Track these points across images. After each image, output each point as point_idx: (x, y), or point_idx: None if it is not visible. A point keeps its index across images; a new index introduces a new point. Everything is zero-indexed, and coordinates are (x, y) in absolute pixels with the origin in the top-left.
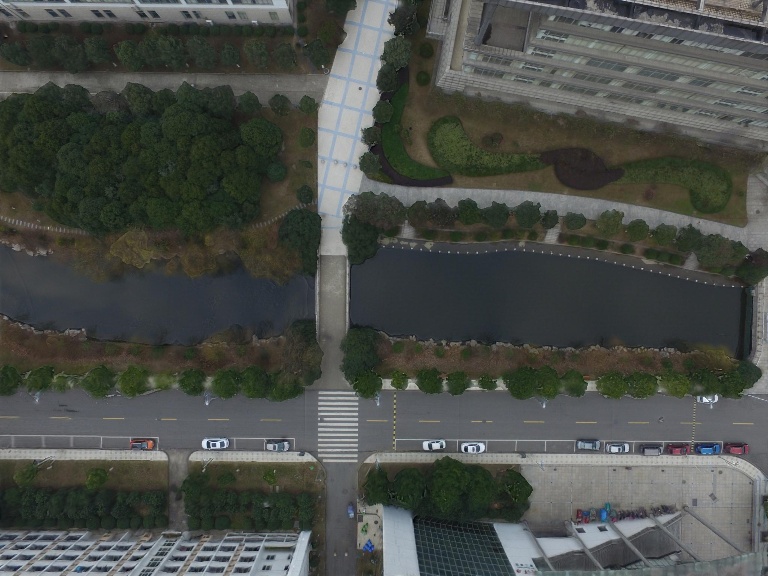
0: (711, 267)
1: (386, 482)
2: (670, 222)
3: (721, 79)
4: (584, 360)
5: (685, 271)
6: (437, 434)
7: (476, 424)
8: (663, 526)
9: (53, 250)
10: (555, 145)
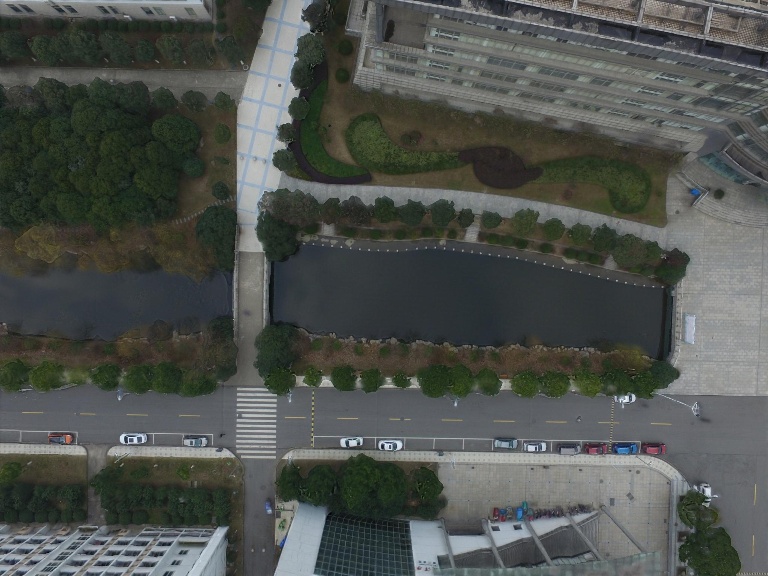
0: (630, 267)
1: (298, 478)
2: (589, 222)
3: (616, 78)
4: (503, 359)
5: (606, 271)
6: (355, 431)
7: (394, 422)
8: (576, 525)
9: None
10: (474, 143)
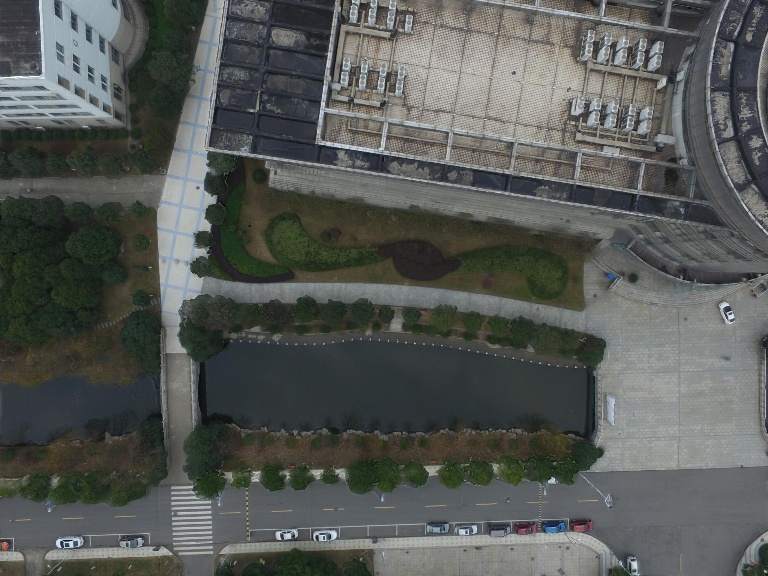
0: None
1: None
2: (510, 308)
3: None
4: (432, 445)
5: (529, 353)
6: (290, 523)
7: (328, 512)
8: None
9: None
10: (393, 238)
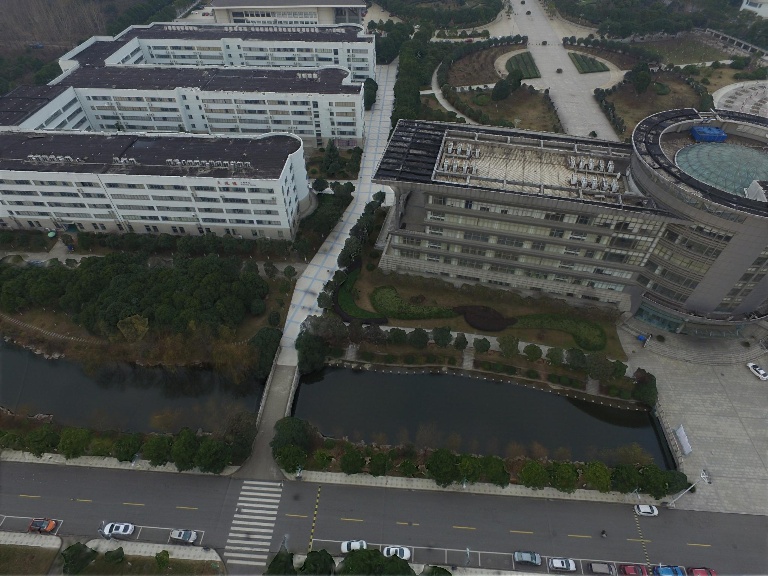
0: (609, 390)
1: (290, 567)
2: None
3: (545, 239)
4: (510, 467)
5: (590, 396)
6: (359, 536)
7: (401, 526)
8: None
9: (65, 355)
10: (464, 304)
